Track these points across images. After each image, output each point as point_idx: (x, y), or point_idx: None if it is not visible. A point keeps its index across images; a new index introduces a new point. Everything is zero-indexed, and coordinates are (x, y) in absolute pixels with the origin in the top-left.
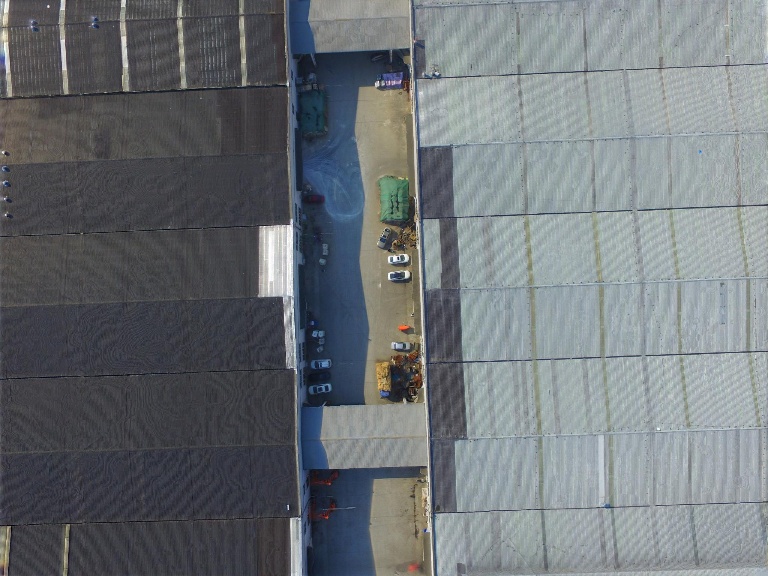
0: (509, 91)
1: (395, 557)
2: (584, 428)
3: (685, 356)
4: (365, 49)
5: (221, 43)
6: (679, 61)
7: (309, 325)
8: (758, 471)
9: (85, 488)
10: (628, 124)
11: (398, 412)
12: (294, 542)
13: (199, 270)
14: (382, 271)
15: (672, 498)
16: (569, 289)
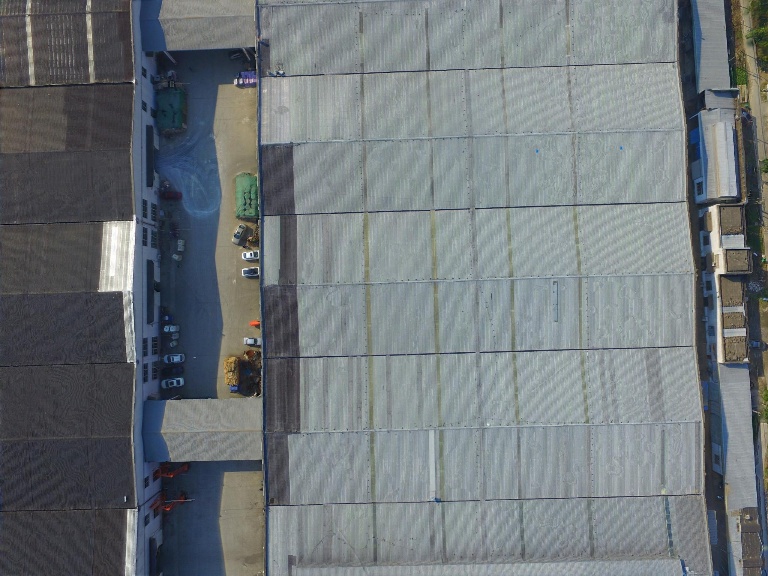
0: (351, 90)
1: (244, 549)
2: (415, 423)
3: (518, 353)
4: (216, 47)
5: (69, 40)
6: (520, 61)
7: (163, 320)
8: (586, 467)
9: None
10: (466, 123)
11: (239, 406)
12: (130, 533)
13: (42, 264)
14: (237, 267)
15: (502, 493)
16: (404, 286)
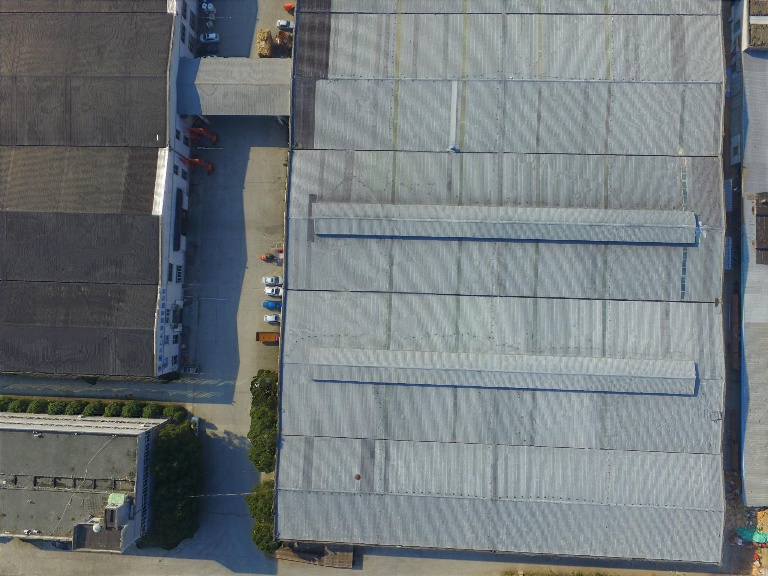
0: None
1: (265, 220)
2: (439, 74)
3: (544, 15)
4: None
5: None
6: None
7: (201, 1)
8: (605, 124)
9: None
10: None
11: (270, 64)
12: (160, 169)
13: None
14: None
15: (520, 146)
16: None
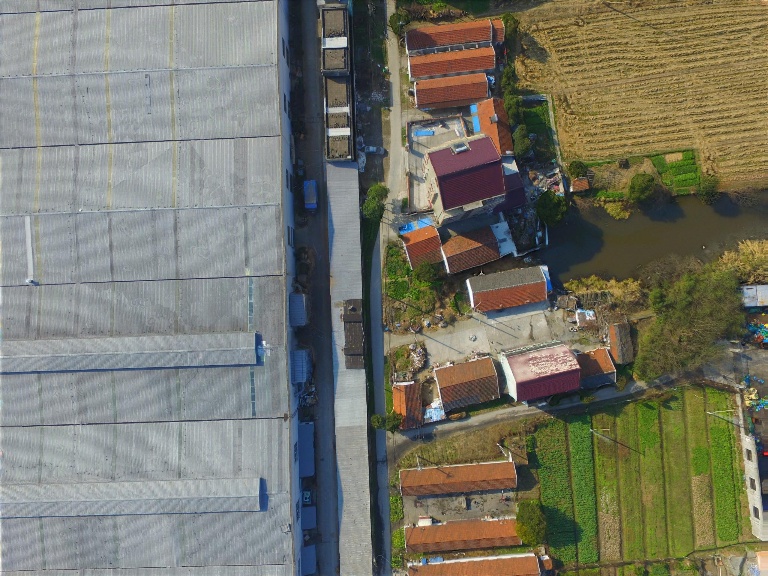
0: None
1: None
2: (12, 210)
3: (114, 145)
4: None
5: None
6: None
7: None
8: (174, 250)
9: None
10: None
11: None
12: None
13: None
14: None
15: (95, 276)
16: (5, 82)
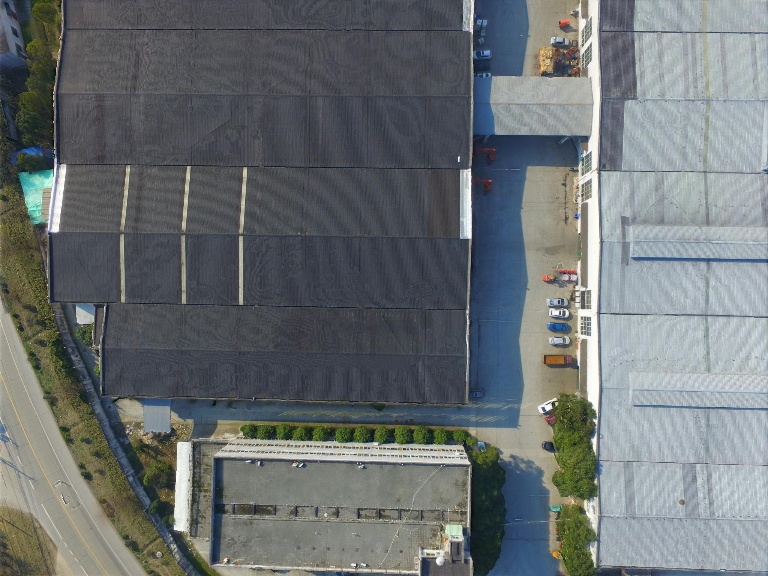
0: None
1: (544, 241)
2: (751, 94)
3: None
4: None
5: None
6: None
7: None
8: None
9: (264, 131)
10: None
11: (565, 83)
12: (463, 191)
13: None
14: None
15: None
16: None
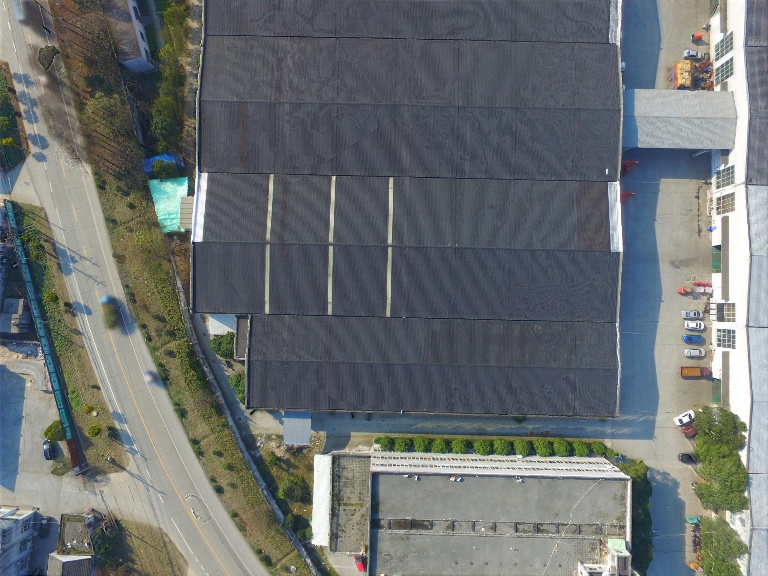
0: None
1: (678, 253)
2: None
3: None
4: None
5: None
6: None
7: None
8: None
9: (412, 142)
10: None
11: (708, 97)
12: (612, 204)
13: None
14: None
15: None
16: None
